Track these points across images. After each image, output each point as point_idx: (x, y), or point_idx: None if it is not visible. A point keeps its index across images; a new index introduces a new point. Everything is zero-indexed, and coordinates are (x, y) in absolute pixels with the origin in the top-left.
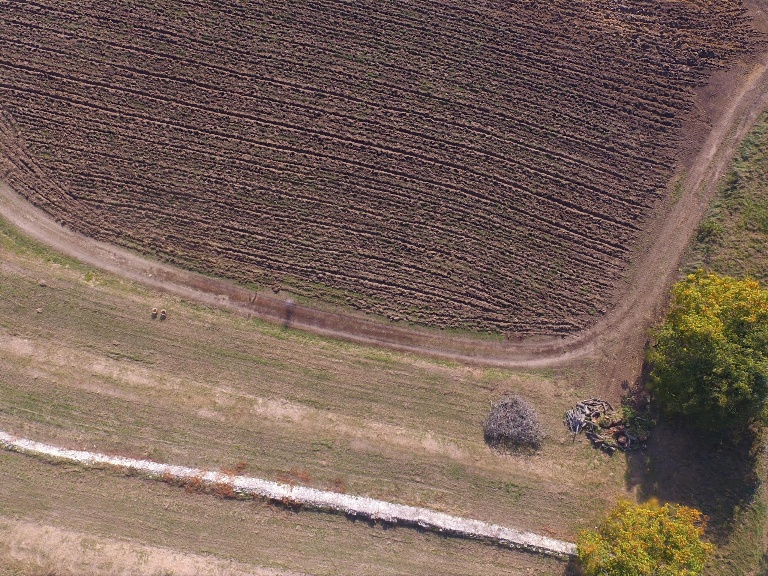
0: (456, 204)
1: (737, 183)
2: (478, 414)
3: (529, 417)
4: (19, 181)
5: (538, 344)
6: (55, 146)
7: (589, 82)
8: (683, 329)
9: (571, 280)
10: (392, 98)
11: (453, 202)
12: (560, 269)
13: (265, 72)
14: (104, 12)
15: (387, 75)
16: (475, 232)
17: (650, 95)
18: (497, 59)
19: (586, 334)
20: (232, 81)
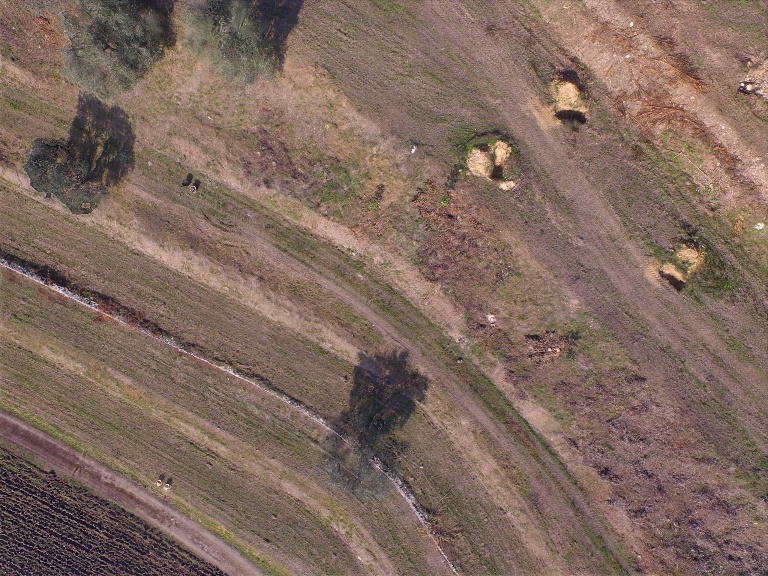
0: None
1: None
2: None
3: None
4: None
5: None
6: None
7: None
8: None
9: None
10: None
11: None
12: None
13: None
14: None
15: None
16: None
17: None
18: None
19: None
20: None
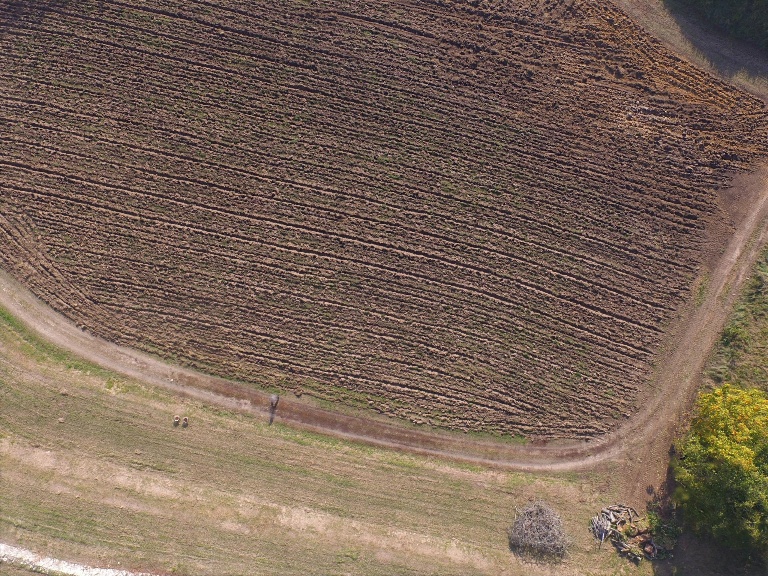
0: (479, 307)
1: (761, 288)
2: (503, 521)
3: (555, 527)
4: (39, 286)
5: (562, 447)
6: (75, 250)
7: (611, 184)
8: (712, 452)
9: (595, 383)
10: (413, 200)
11: (476, 305)
12: (584, 372)
13: (286, 174)
14: (124, 114)
15: (408, 177)
16: (498, 335)
17: (673, 197)
18: (519, 160)
19: (610, 437)
20: (253, 183)
